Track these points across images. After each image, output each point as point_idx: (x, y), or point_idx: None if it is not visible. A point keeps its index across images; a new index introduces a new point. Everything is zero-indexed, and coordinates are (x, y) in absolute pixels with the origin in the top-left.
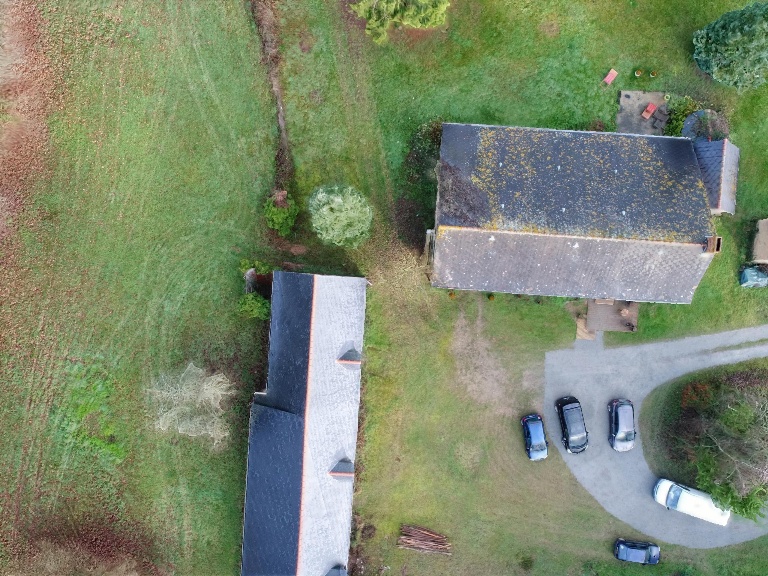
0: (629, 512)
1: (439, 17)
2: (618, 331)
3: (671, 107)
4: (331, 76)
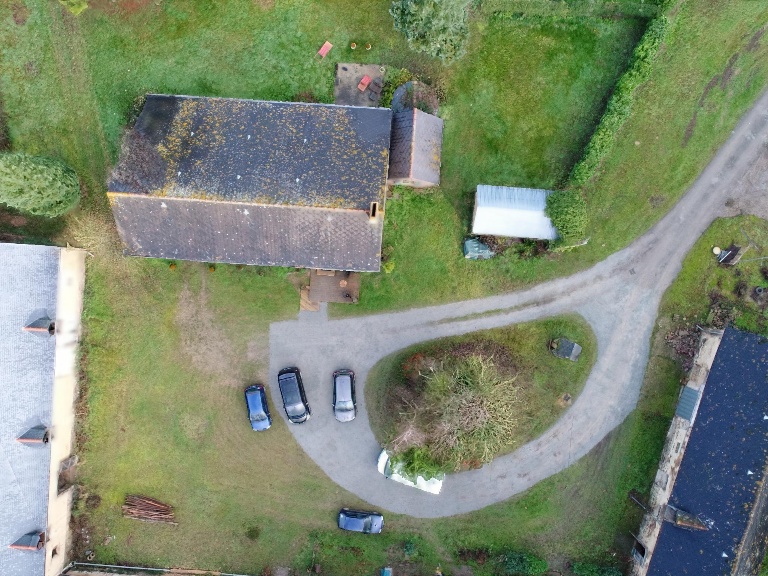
0: (355, 482)
1: None
2: (342, 302)
3: (387, 79)
4: (46, 48)
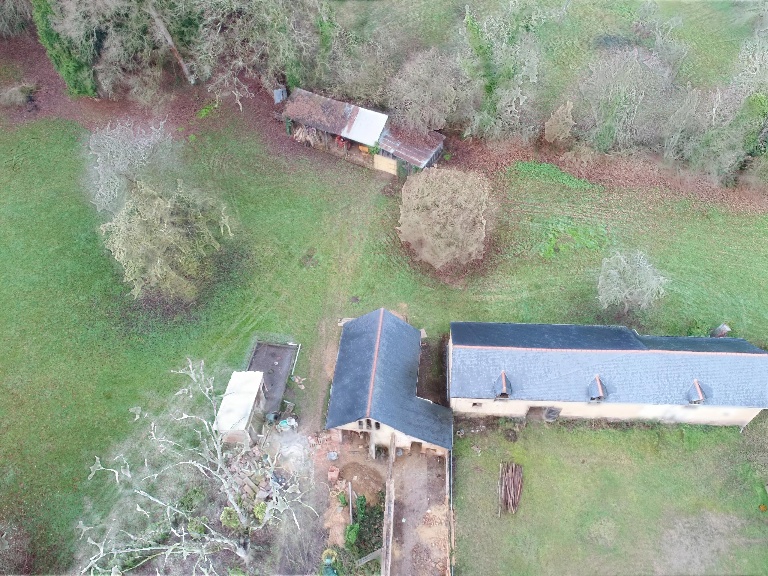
0: None
1: None
2: None
3: None
4: None
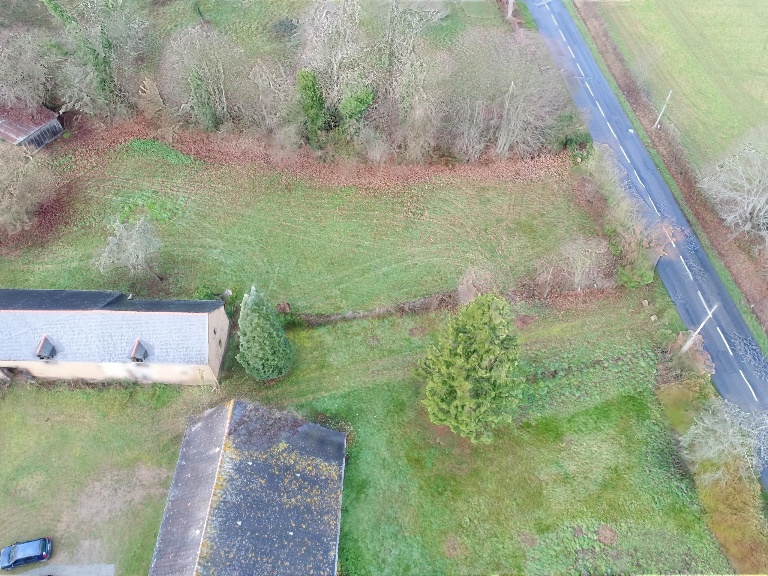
0: None
1: (431, 411)
2: None
3: None
4: (391, 351)
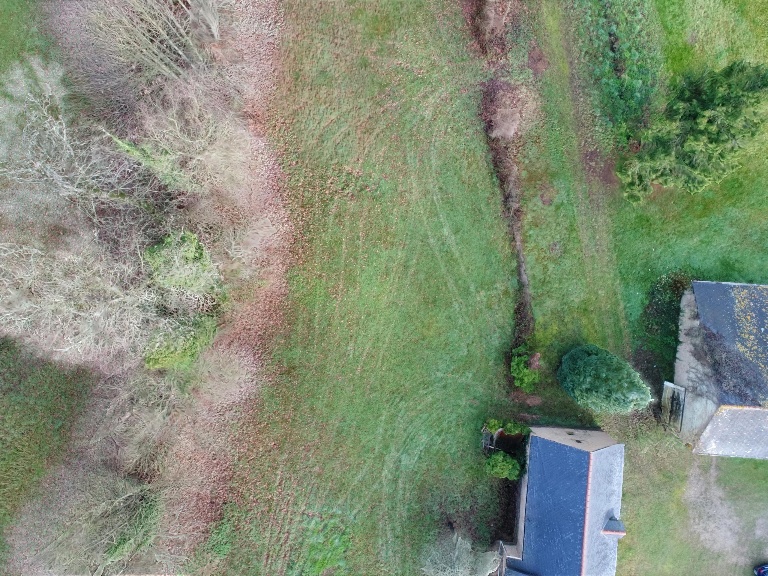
0: None
1: None
2: None
3: None
4: (571, 228)
